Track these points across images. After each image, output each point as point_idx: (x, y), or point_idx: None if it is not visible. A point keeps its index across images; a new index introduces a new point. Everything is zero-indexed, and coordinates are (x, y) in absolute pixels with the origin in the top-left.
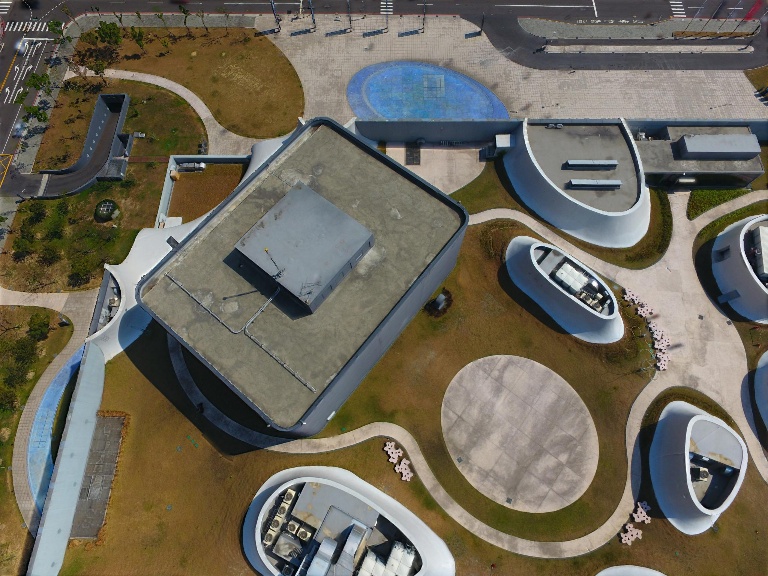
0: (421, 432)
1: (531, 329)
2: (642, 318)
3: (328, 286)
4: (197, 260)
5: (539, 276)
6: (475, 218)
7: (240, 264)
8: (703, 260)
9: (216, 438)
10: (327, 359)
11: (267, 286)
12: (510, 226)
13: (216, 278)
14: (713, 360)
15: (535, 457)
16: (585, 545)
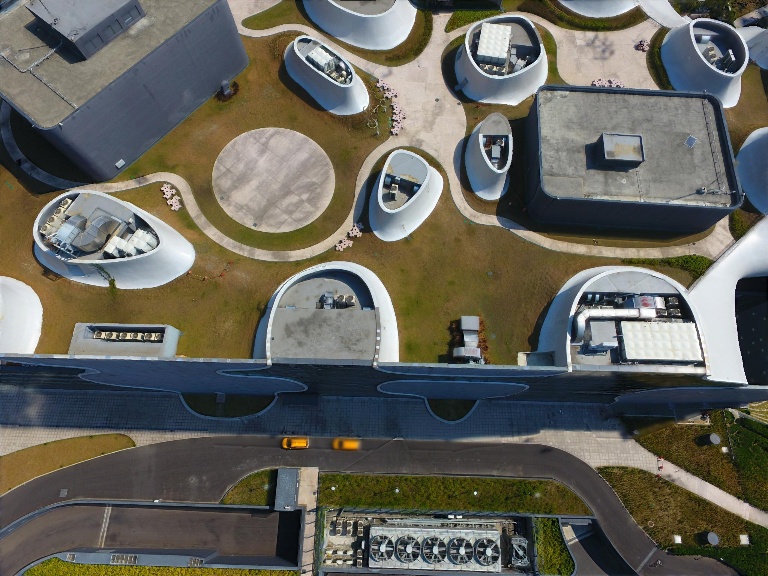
0: (195, 180)
1: (298, 109)
2: (388, 100)
3: (95, 34)
4: (3, 26)
5: (299, 60)
6: (269, 31)
7: (37, 28)
8: (449, 60)
9: (28, 183)
10: (91, 88)
11: (55, 42)
12: (295, 36)
13: (16, 37)
14: (439, 129)
15: (282, 196)
16: (308, 253)
